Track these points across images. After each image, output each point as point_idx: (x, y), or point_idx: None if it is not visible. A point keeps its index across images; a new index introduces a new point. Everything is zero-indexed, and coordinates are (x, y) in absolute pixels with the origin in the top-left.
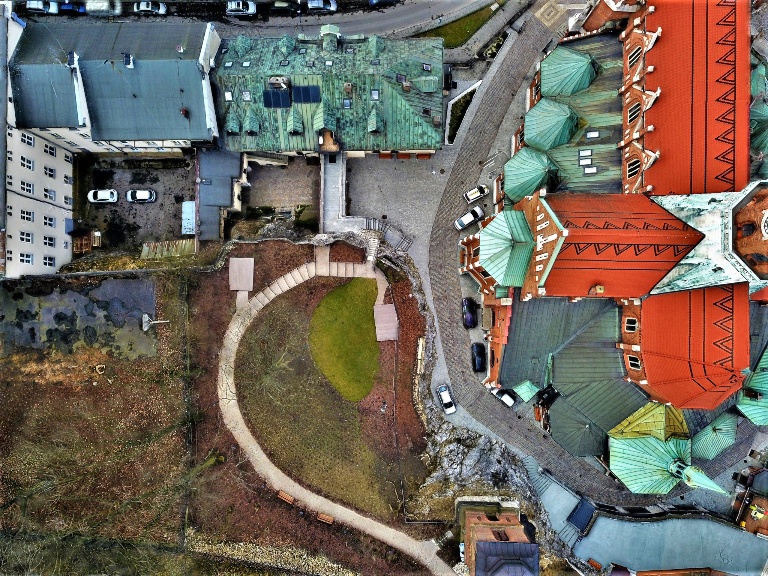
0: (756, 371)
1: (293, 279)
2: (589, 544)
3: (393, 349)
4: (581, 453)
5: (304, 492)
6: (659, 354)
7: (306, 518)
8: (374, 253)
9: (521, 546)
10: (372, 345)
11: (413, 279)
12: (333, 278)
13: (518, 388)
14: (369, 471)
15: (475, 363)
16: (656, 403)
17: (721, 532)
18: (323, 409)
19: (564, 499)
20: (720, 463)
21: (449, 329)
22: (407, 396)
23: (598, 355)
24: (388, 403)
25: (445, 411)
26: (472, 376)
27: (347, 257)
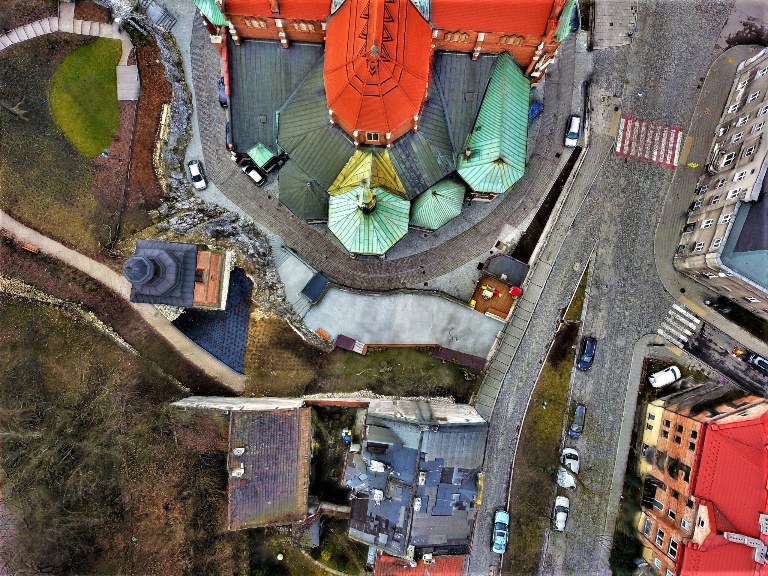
0: (473, 132)
1: (33, 30)
2: (320, 315)
3: (133, 109)
4: (307, 216)
5: (13, 223)
6: (332, 70)
7: (12, 246)
8: (122, 16)
9: (178, 245)
10: (113, 104)
11: (165, 49)
12: (77, 35)
13: (251, 151)
14: (88, 214)
15: (226, 138)
16: (364, 152)
17: (452, 310)
18: (54, 158)
19: (301, 272)
20: (466, 252)
21: (206, 108)
22: (146, 158)
23: (313, 105)
24: (124, 161)
25: (195, 185)
26: (226, 155)
27: (93, 16)
